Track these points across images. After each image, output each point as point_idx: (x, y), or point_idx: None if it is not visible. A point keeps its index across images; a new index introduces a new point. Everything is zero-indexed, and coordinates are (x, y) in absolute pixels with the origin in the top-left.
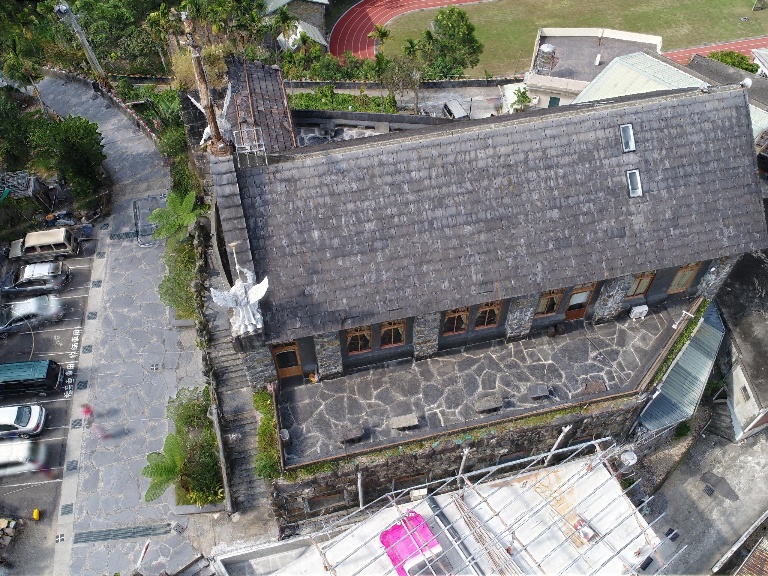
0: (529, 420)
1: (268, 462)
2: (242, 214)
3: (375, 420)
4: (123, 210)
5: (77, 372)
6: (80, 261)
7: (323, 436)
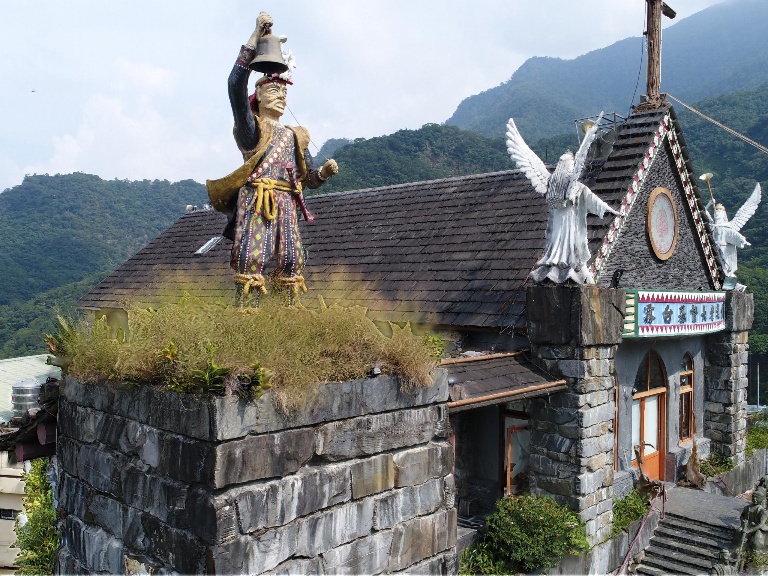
0: None
1: None
2: None
3: None
4: None
5: None
6: None
7: None
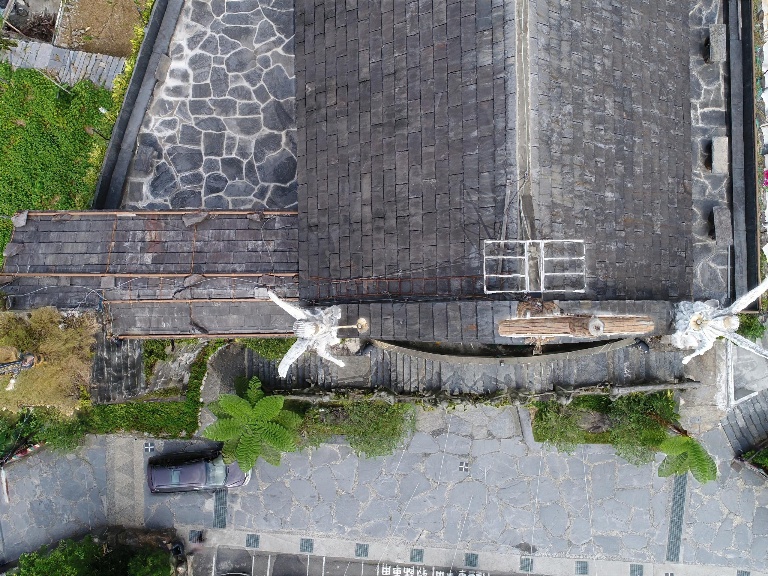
0: (754, 0)
1: (759, 329)
2: (608, 304)
3: (697, 191)
4: (167, 509)
5: (450, 568)
6: (258, 571)
7: (705, 259)
